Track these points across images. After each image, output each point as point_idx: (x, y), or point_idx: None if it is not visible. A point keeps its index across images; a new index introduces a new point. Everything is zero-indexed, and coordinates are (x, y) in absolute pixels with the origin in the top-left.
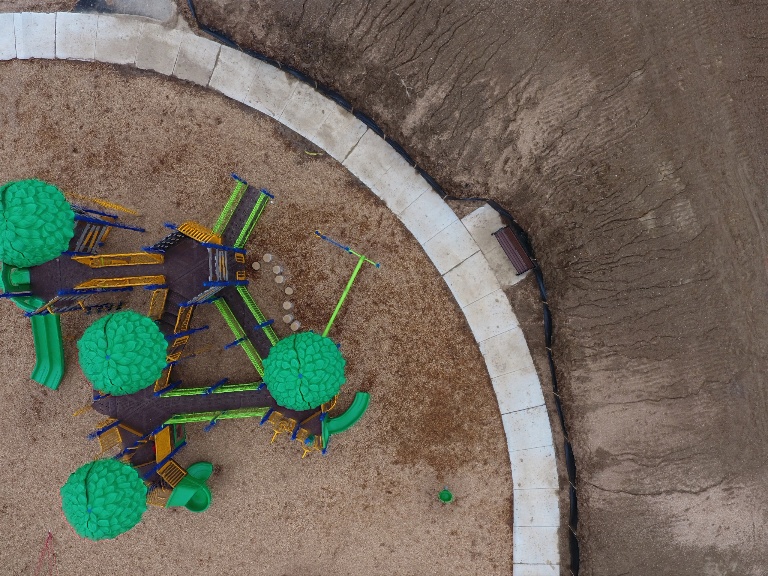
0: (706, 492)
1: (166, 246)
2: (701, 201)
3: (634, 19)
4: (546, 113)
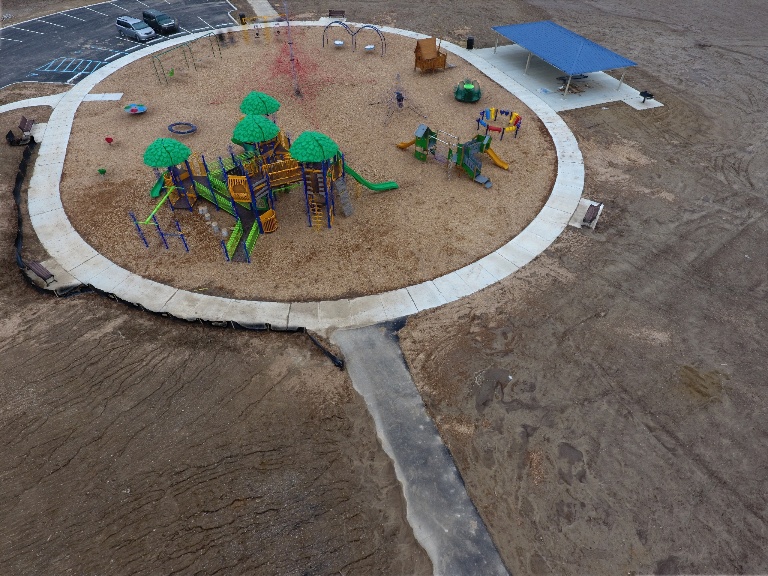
0: None
1: (266, 191)
2: None
3: None
4: None
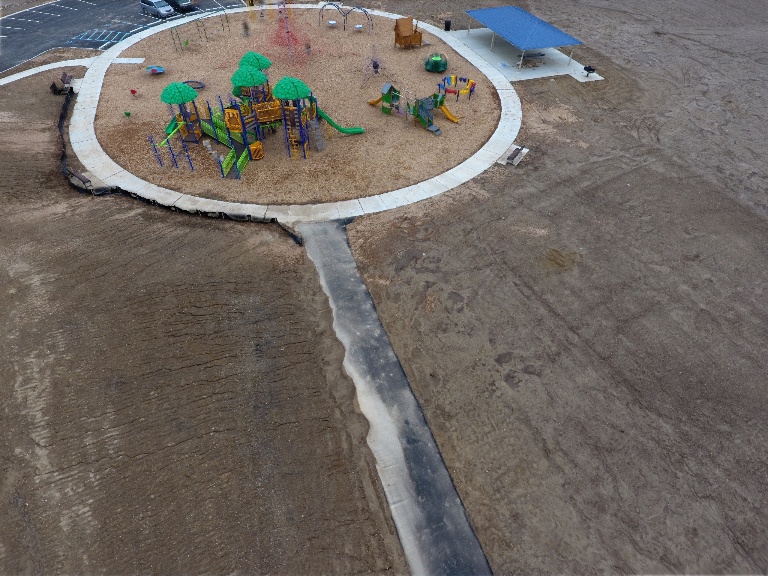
0: None
1: (255, 124)
2: None
3: None
4: None
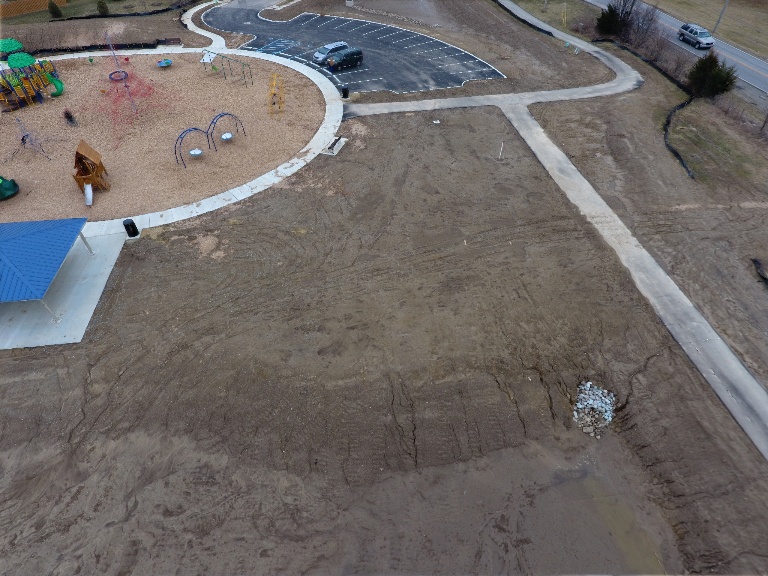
0: None
1: None
2: None
3: None
4: None
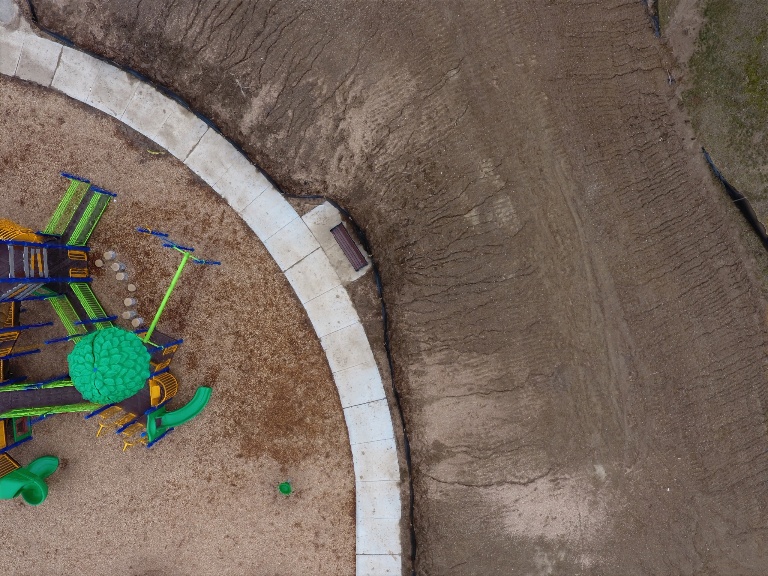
0: (534, 483)
1: None
2: (520, 198)
3: (447, 19)
4: (372, 112)
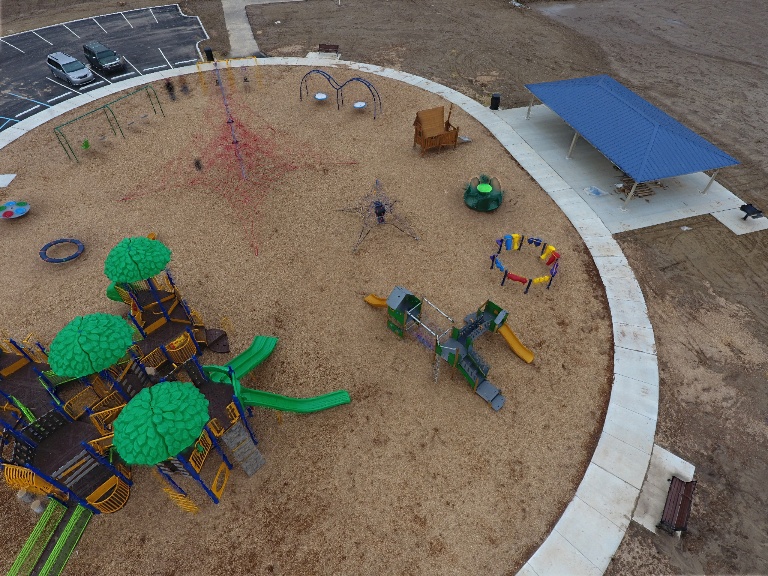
0: None
1: (92, 464)
2: None
3: None
4: None
